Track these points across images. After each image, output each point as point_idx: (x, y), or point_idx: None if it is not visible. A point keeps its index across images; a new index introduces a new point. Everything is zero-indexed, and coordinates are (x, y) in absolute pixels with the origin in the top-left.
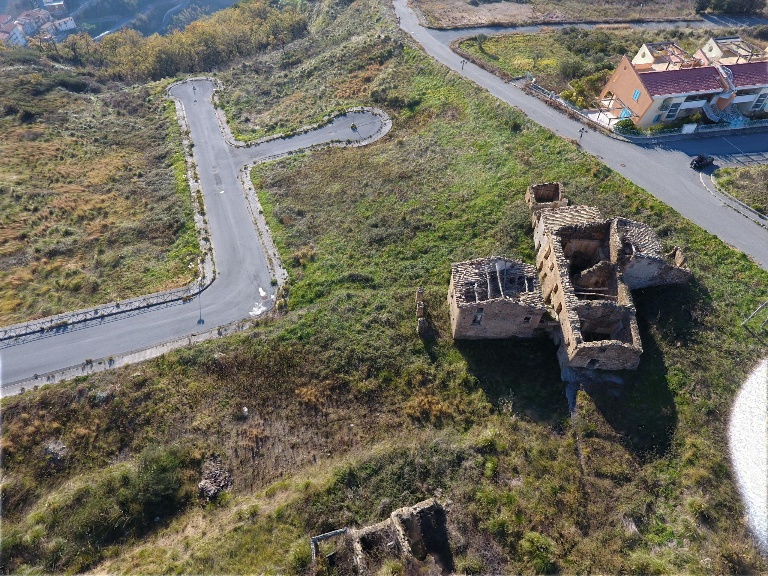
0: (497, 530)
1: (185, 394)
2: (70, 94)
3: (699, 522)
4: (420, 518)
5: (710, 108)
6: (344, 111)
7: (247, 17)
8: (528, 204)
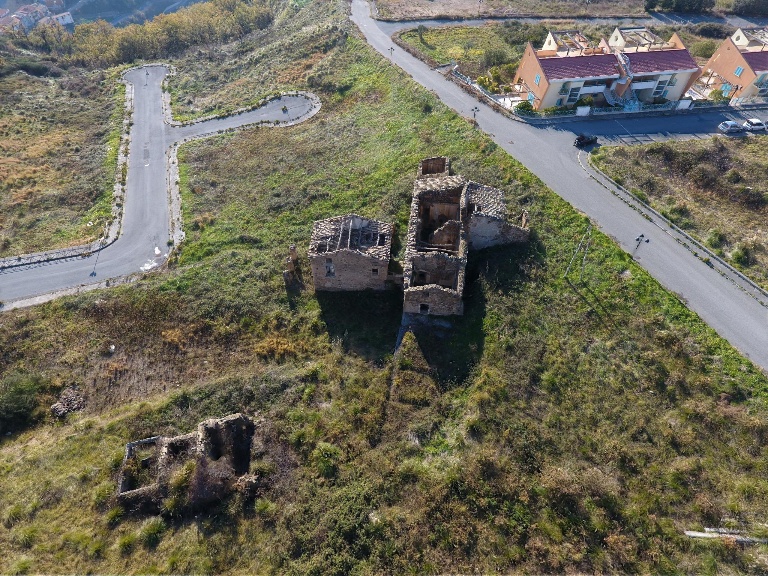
0: (294, 441)
1: (62, 334)
2: (29, 77)
3: (468, 435)
4: (224, 428)
5: (610, 93)
6: (279, 95)
7: (217, 10)
8: (416, 176)
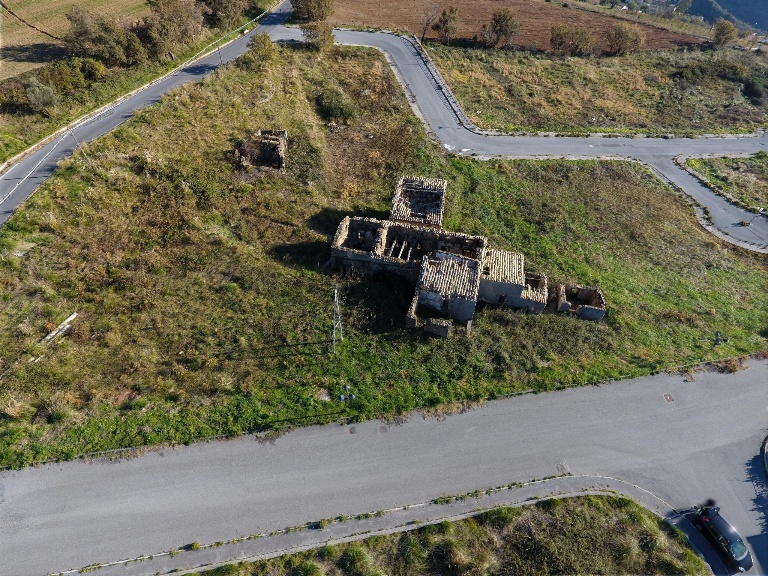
0: None
1: None
2: (734, 90)
3: None
4: None
5: None
6: None
7: None
8: None
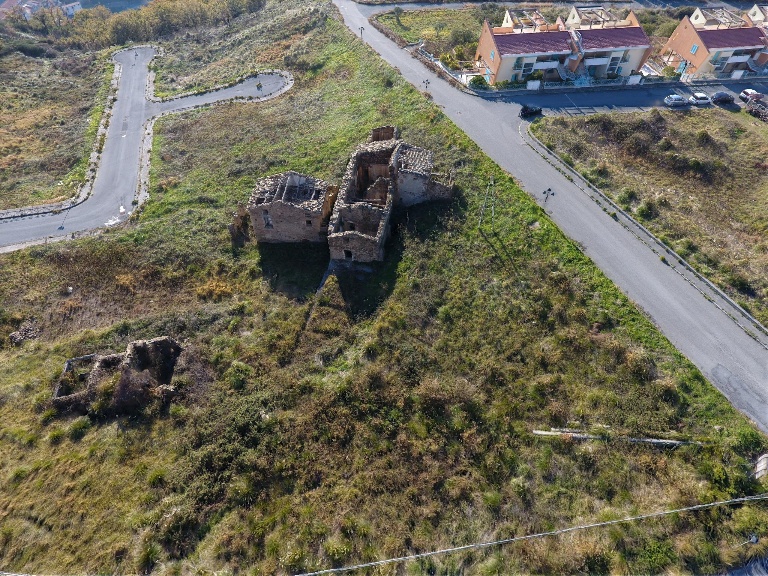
0: (213, 360)
1: (27, 277)
2: (25, 58)
3: (364, 356)
4: (151, 347)
5: (563, 69)
6: (256, 73)
7: None
8: None
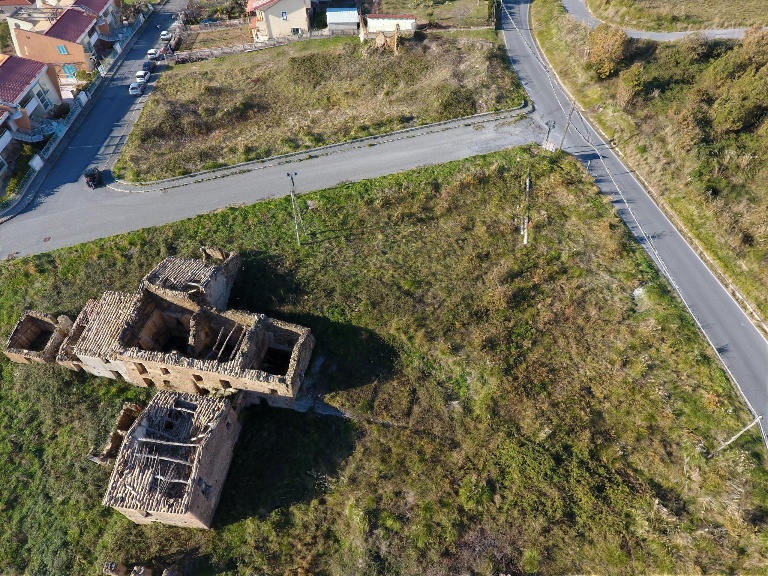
0: (457, 532)
1: None
2: None
3: (457, 354)
4: None
5: (20, 134)
6: None
7: None
8: (33, 362)
